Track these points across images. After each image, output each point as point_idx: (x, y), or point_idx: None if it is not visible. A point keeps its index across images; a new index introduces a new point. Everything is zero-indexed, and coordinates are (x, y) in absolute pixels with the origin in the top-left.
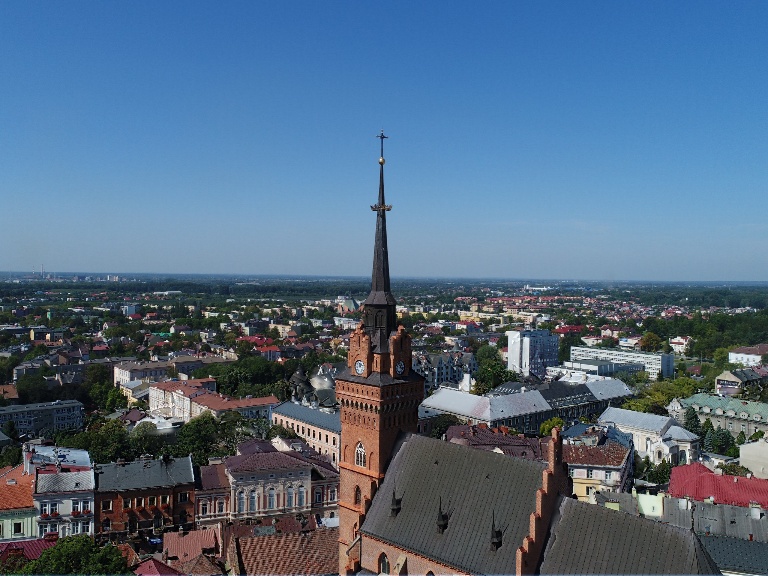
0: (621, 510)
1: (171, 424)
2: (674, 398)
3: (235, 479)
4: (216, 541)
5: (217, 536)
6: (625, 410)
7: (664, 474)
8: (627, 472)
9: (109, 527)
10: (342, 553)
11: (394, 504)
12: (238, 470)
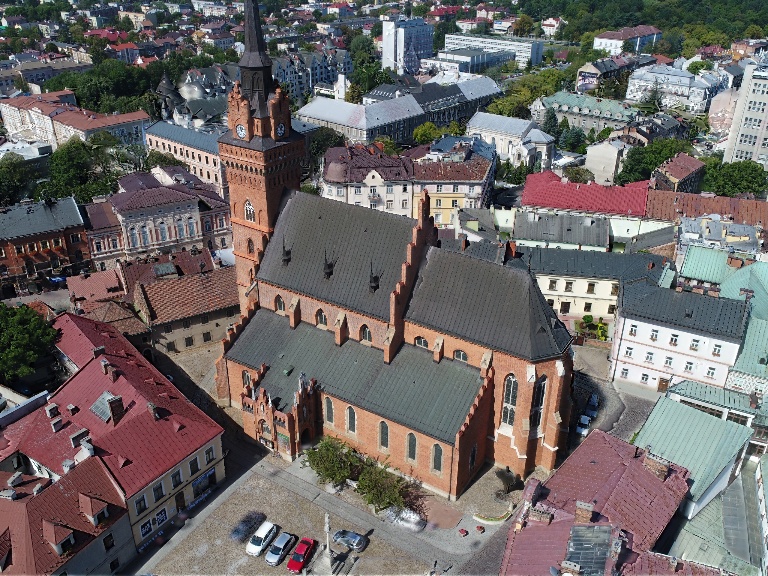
0: (480, 226)
1: (37, 149)
2: None
3: (124, 217)
4: (119, 280)
5: (119, 275)
6: (492, 114)
7: (521, 176)
8: (489, 181)
9: (7, 272)
10: (241, 293)
11: (285, 255)
12: (126, 209)
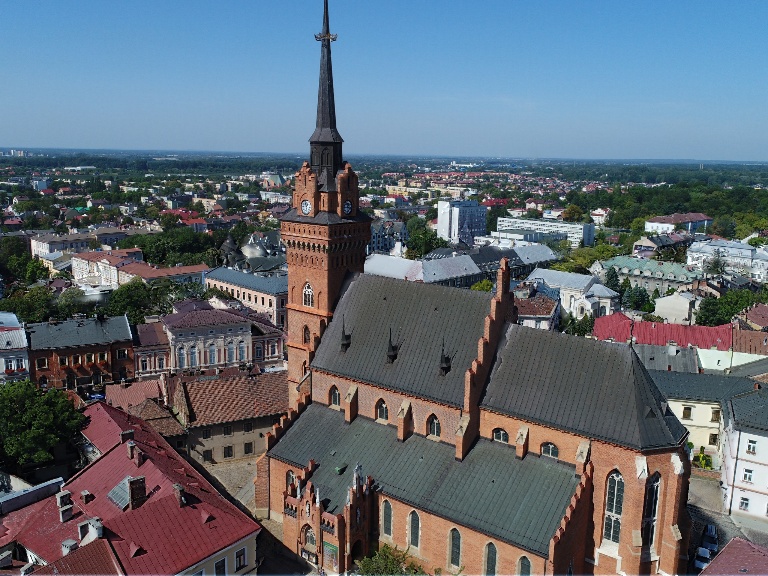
0: None
1: None
2: (596, 260)
3: (174, 335)
4: (160, 392)
5: (161, 387)
6: (551, 270)
7: (586, 327)
8: (554, 323)
9: (46, 384)
10: (291, 391)
11: (344, 339)
12: (177, 326)
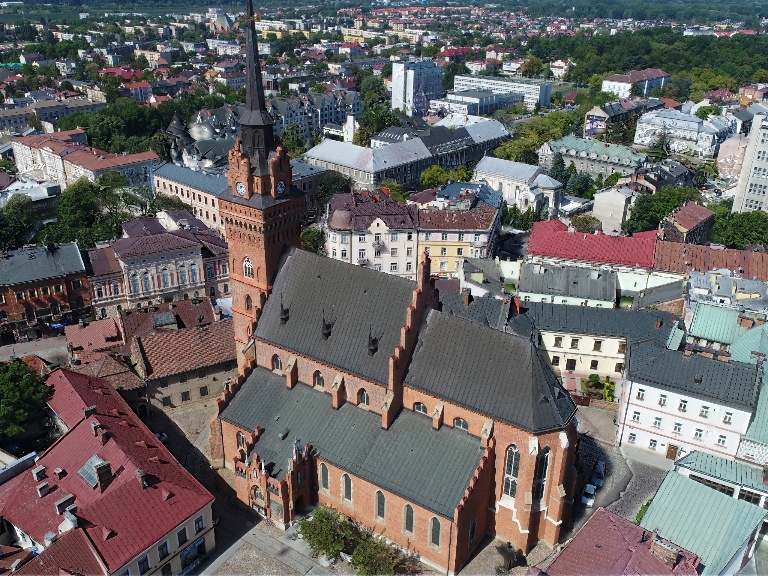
0: (485, 277)
1: (46, 189)
2: (545, 142)
3: (126, 264)
4: (117, 329)
5: (118, 324)
6: (499, 159)
7: (528, 221)
8: (495, 229)
9: (6, 318)
10: (239, 349)
11: (283, 314)
12: (128, 255)
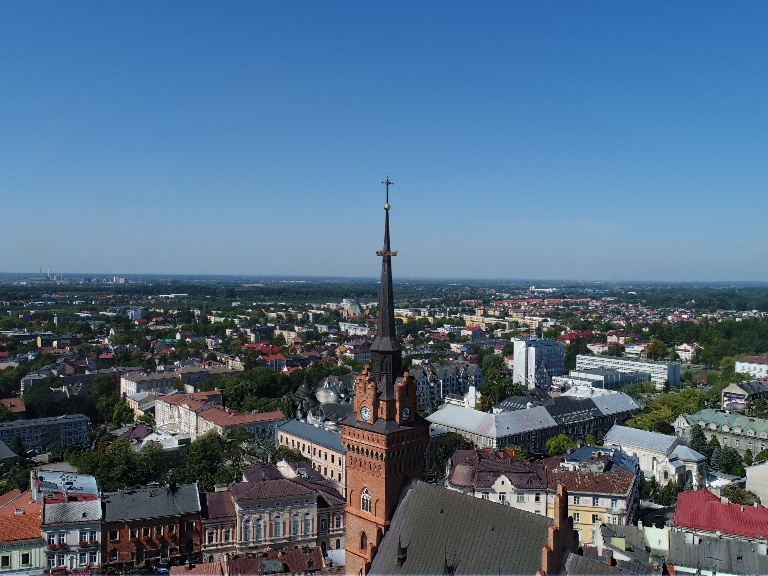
0: (627, 544)
1: (177, 441)
2: (680, 414)
3: (241, 508)
4: (222, 575)
5: (223, 569)
6: (631, 428)
7: (670, 496)
8: (633, 497)
9: (116, 557)
10: None
11: (400, 553)
12: (244, 499)
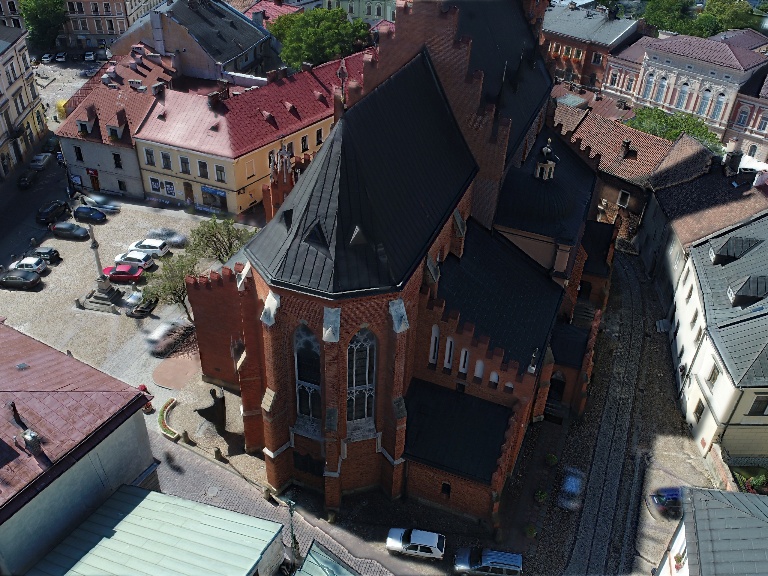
0: None
1: None
2: None
3: (648, 56)
4: None
5: None
6: None
7: None
8: None
9: None
10: None
11: None
12: (654, 46)
